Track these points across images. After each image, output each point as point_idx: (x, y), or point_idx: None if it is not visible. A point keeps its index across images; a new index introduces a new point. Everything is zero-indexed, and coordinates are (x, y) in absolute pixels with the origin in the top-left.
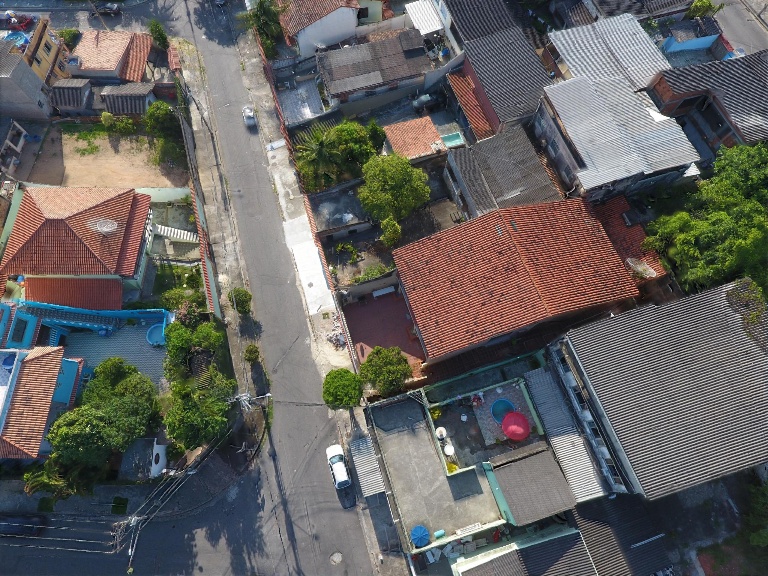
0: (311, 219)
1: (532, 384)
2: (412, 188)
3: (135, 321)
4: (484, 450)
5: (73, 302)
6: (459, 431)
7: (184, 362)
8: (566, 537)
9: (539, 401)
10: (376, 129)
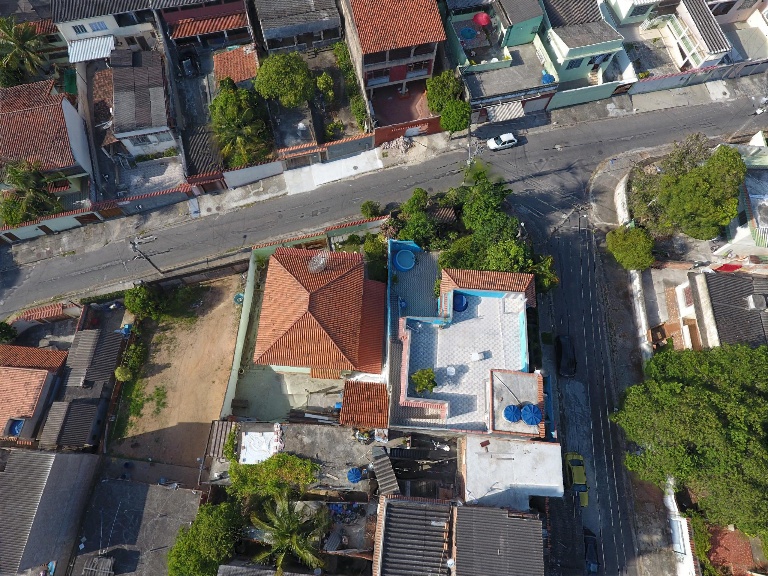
0: (303, 147)
1: (456, 6)
2: (294, 59)
3: (393, 278)
4: (493, 47)
5: (376, 326)
6: (481, 58)
7: (435, 225)
8: (544, 3)
9: (467, 4)
10: (229, 79)
